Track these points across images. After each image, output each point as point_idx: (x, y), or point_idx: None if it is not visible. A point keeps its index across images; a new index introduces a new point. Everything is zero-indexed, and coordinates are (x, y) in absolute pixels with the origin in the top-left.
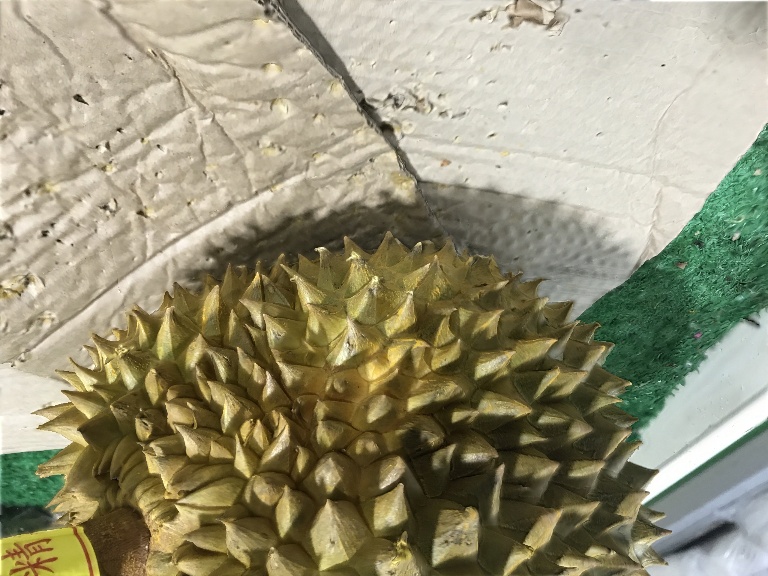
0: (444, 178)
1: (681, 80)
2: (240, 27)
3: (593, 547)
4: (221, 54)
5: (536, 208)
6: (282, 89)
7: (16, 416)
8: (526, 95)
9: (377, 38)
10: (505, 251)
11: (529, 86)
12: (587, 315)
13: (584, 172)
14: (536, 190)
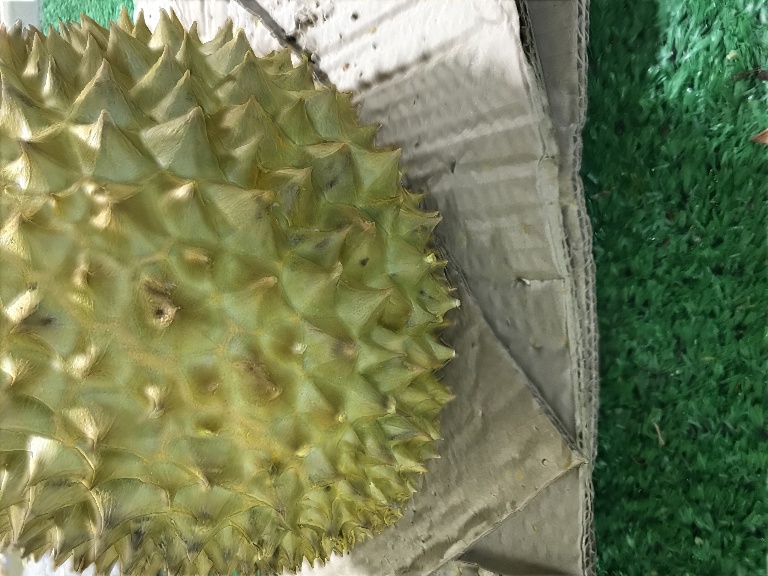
0: (349, 82)
1: None
2: None
3: None
4: None
5: (414, 74)
6: None
7: None
8: None
9: None
10: (406, 140)
11: None
12: (663, 311)
13: None
14: (406, 53)
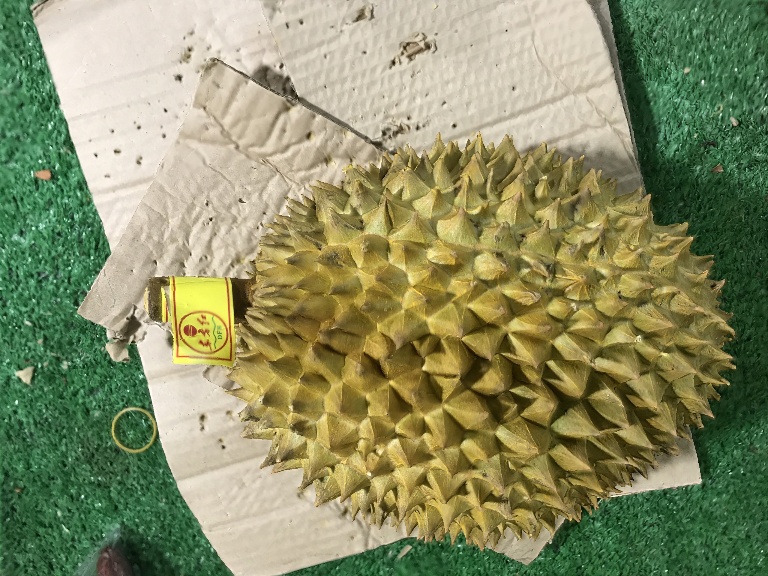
0: None
1: (524, 31)
2: (284, 118)
3: (536, 187)
4: (286, 140)
5: None
6: (322, 146)
7: (282, 509)
8: (451, 91)
9: (353, 102)
10: None
11: (448, 85)
12: None
13: (530, 118)
14: None
